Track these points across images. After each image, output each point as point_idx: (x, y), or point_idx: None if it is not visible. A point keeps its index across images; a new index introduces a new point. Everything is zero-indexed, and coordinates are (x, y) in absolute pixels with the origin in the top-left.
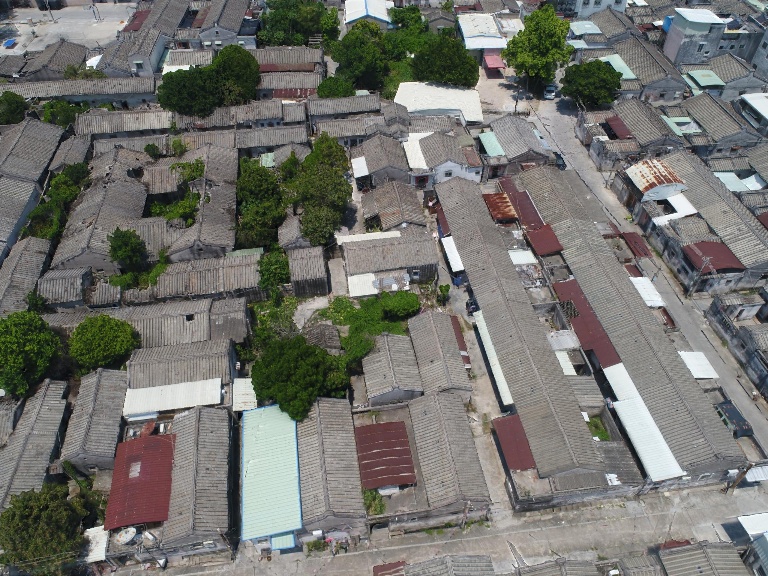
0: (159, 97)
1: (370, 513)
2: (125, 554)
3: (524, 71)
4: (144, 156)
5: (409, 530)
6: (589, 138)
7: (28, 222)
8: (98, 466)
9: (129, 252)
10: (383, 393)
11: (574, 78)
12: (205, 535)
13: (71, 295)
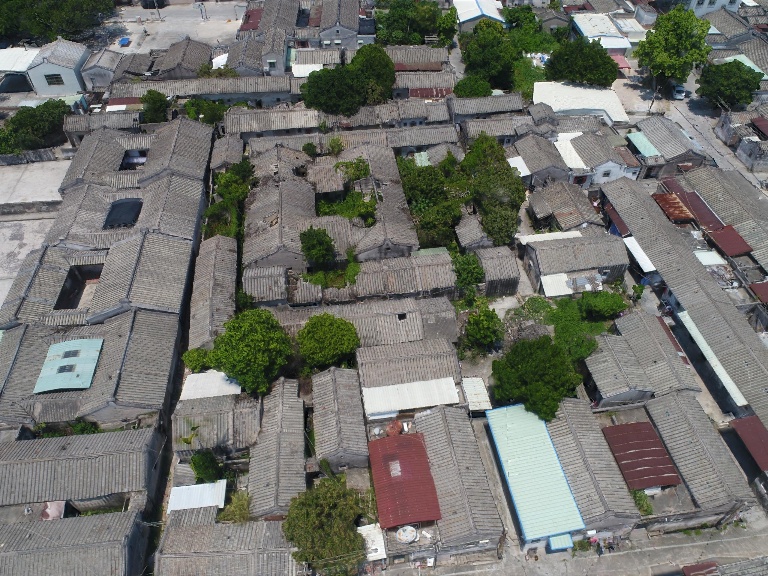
0: (304, 96)
1: (640, 513)
2: (406, 552)
3: (660, 71)
4: (303, 155)
5: (666, 530)
6: (734, 139)
7: (205, 220)
8: (349, 464)
9: (323, 251)
10: (619, 393)
11: (715, 78)
12: (486, 534)
13: (276, 293)
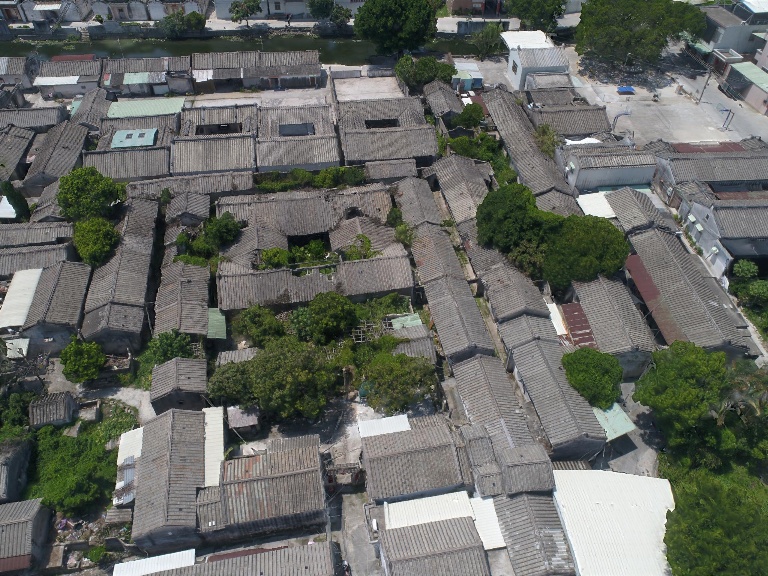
0: None
1: None
2: None
3: None
4: (387, 213)
5: None
6: None
7: None
8: None
9: None
10: None
11: None
12: None
13: (170, 214)
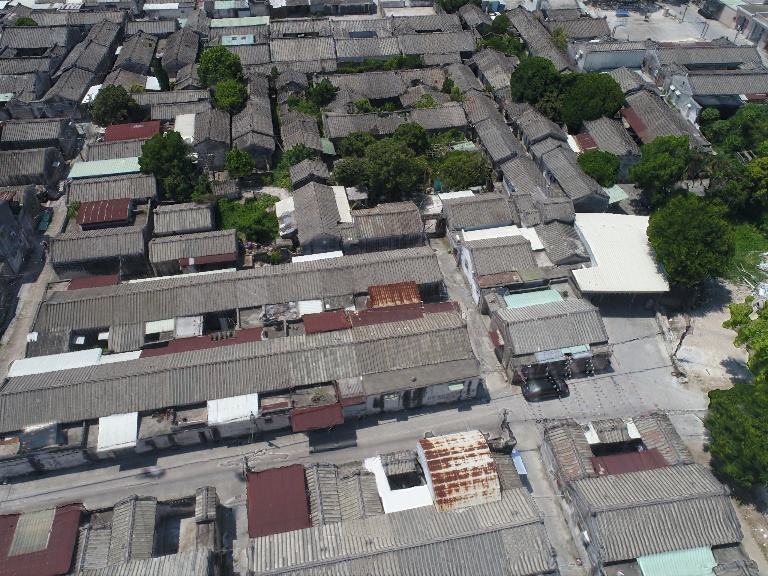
0: None
1: None
2: None
3: None
4: (442, 84)
5: None
6: None
7: None
8: None
9: None
10: None
11: None
12: None
13: (280, 84)
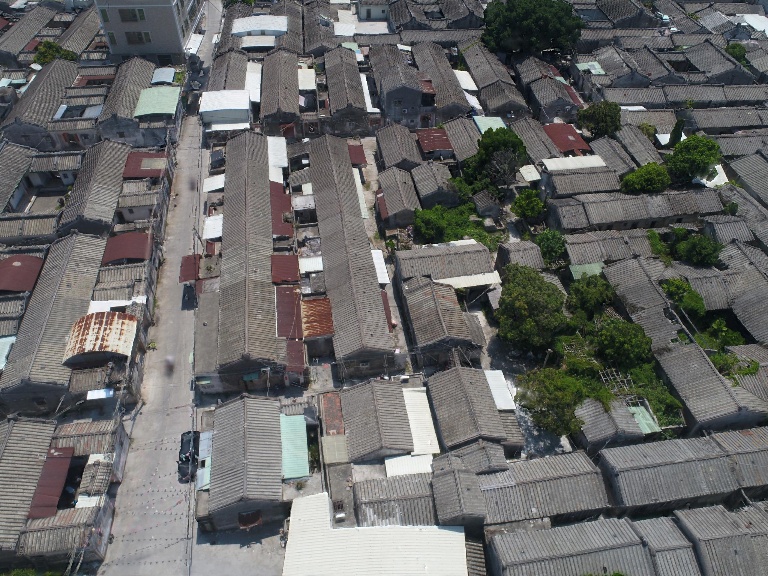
0: None
1: None
2: None
3: None
4: None
5: None
6: None
7: None
8: None
9: None
10: None
11: None
12: None
13: None
